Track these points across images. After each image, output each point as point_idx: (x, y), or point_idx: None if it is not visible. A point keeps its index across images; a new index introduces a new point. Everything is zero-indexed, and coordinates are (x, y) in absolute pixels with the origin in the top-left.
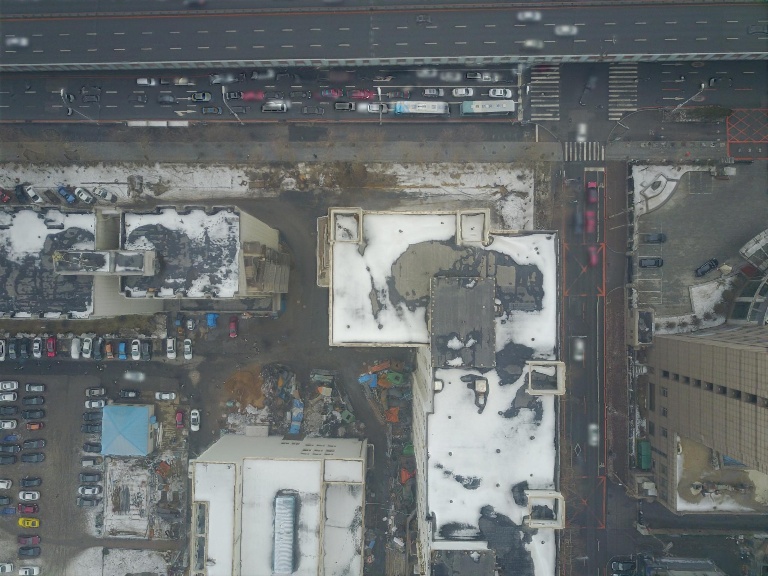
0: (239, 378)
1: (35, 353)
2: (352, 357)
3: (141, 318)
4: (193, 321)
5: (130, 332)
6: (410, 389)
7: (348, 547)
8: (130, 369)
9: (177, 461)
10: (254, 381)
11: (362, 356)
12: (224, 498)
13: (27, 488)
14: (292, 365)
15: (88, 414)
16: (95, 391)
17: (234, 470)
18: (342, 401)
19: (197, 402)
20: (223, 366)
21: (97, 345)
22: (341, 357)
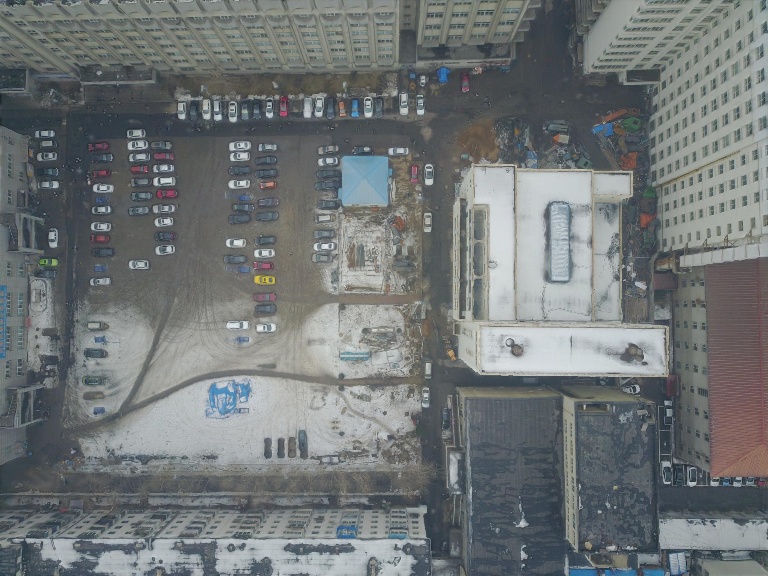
0: (472, 132)
1: (267, 113)
2: (584, 109)
3: (371, 77)
4: (425, 77)
5: (361, 91)
6: (645, 137)
7: (605, 274)
8: (361, 128)
9: (411, 216)
10: (486, 135)
11: (594, 107)
12: (503, 202)
13: (261, 247)
14: (524, 118)
15: (322, 171)
16: (329, 147)
17: (513, 173)
18: (576, 152)
19: (429, 158)
20: (455, 122)
21: (331, 102)
22: (573, 109)
